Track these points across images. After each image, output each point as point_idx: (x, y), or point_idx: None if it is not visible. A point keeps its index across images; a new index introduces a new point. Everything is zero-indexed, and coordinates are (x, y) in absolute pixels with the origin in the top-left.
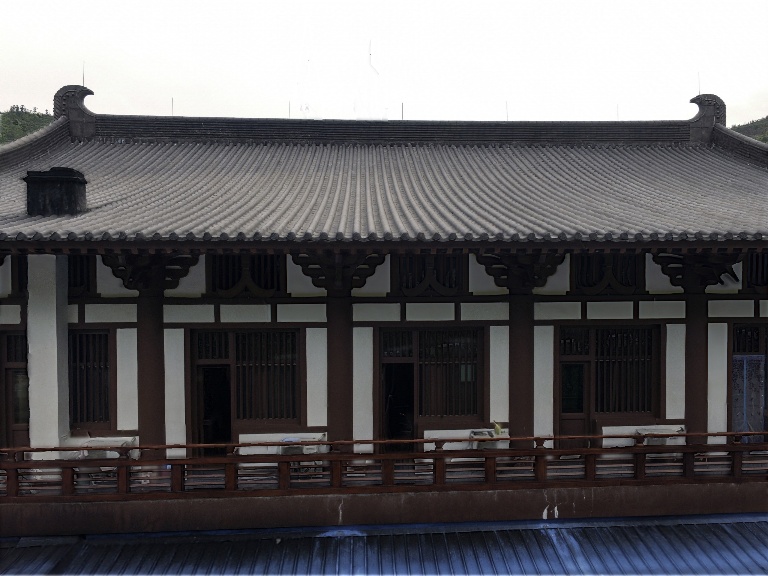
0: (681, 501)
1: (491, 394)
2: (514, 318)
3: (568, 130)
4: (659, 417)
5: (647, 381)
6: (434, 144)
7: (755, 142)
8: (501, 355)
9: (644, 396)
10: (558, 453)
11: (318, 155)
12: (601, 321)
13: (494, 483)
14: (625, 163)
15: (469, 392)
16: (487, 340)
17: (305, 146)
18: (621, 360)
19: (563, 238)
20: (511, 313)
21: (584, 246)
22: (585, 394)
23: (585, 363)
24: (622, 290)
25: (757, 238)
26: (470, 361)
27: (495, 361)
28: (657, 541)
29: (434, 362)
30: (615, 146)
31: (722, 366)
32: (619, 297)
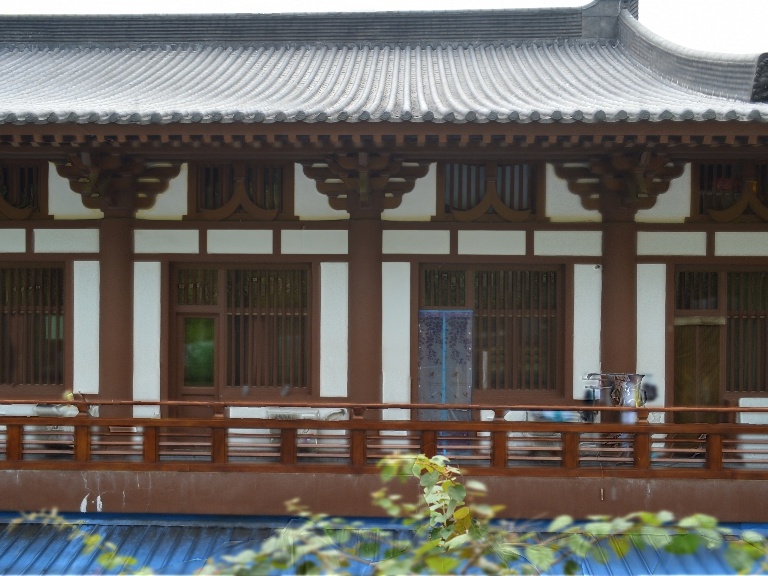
0: (274, 496)
1: (75, 354)
2: (104, 250)
3: (397, 23)
4: (310, 393)
5: (301, 344)
6: (203, 46)
7: (644, 31)
8: (88, 301)
9: (297, 365)
10: (103, 423)
11: (25, 61)
12: (227, 256)
13: (16, 460)
14: (451, 65)
15: (53, 353)
16: (69, 280)
17: (23, 51)
18: (265, 314)
19: (51, 119)
20: (102, 244)
21: (87, 131)
22: (215, 360)
23: (215, 317)
24: (258, 214)
25: (319, 119)
26: (55, 311)
27: (81, 309)
28: (211, 542)
29: (7, 311)
30: (468, 45)
31: (403, 323)
32: (253, 223)
